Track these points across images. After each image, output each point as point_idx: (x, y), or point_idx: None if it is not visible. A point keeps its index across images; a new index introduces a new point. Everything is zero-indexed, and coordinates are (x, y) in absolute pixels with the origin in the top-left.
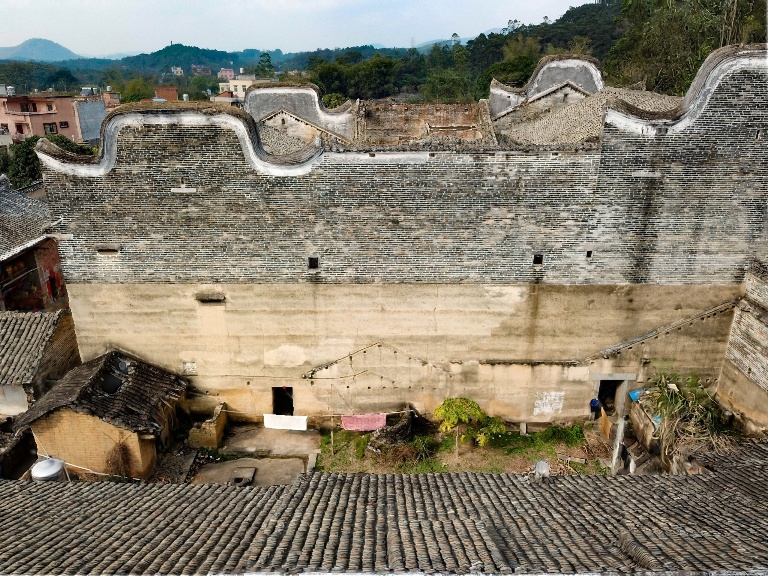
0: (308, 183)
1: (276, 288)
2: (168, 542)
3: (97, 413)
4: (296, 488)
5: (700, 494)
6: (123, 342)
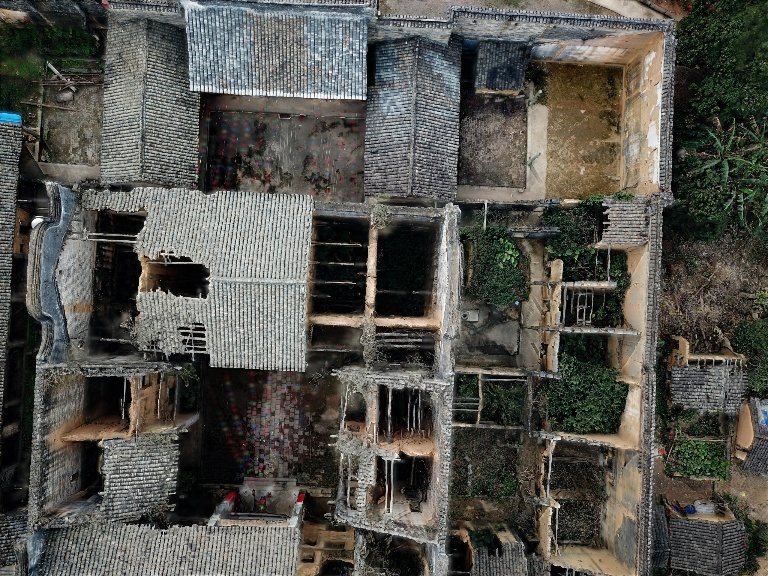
0: None
1: None
2: None
3: None
4: None
5: None
6: None
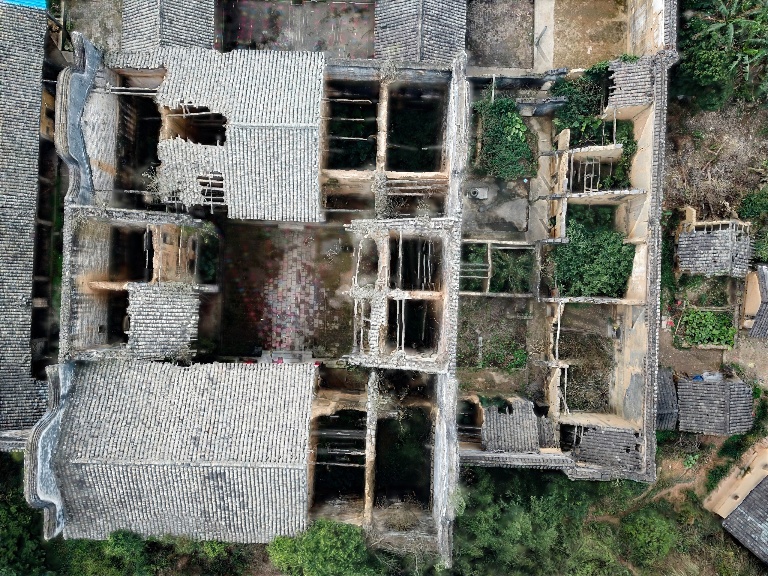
0: None
1: None
2: None
3: None
4: (5, 212)
5: (1, 356)
6: None
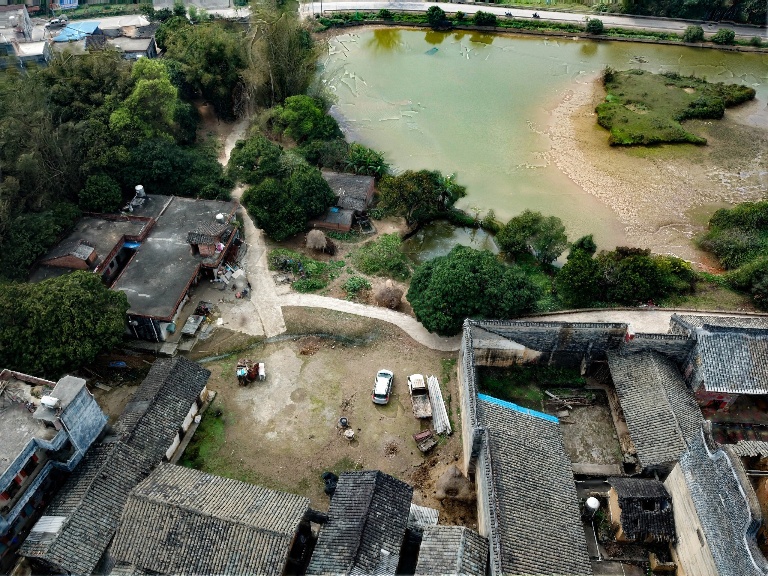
0: (753, 571)
1: (717, 573)
2: (536, 567)
3: (623, 510)
4: None
5: None
6: (674, 500)
